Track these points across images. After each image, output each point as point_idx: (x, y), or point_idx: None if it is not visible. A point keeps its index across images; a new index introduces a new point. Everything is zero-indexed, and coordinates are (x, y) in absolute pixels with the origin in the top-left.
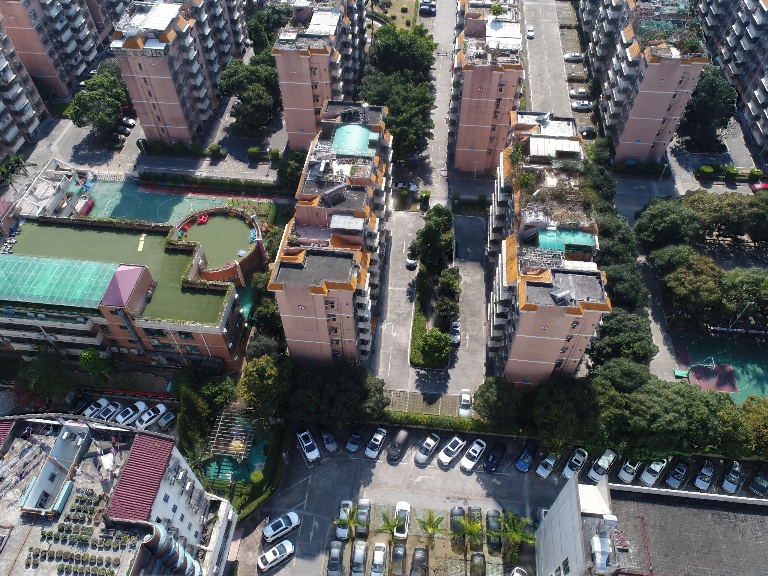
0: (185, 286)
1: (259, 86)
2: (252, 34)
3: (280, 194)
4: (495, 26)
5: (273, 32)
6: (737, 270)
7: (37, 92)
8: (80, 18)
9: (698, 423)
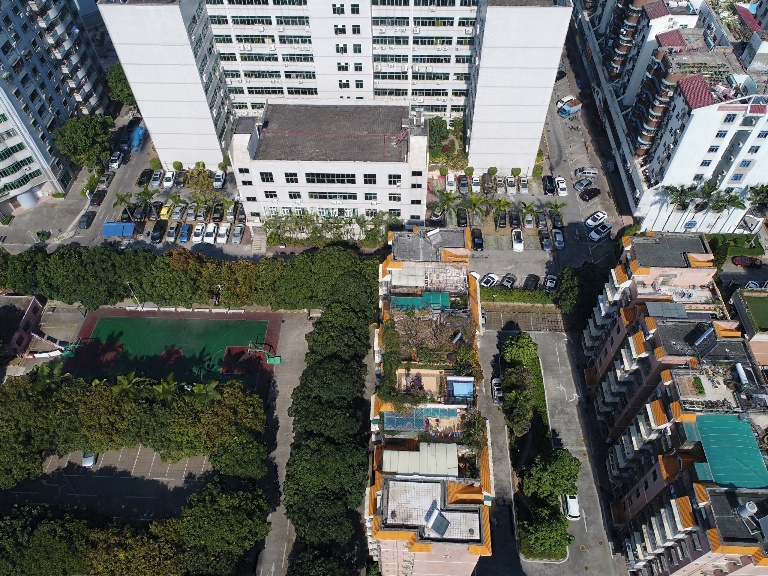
0: None
1: None
2: None
3: None
4: None
5: None
6: (166, 457)
7: None
8: None
9: (306, 254)
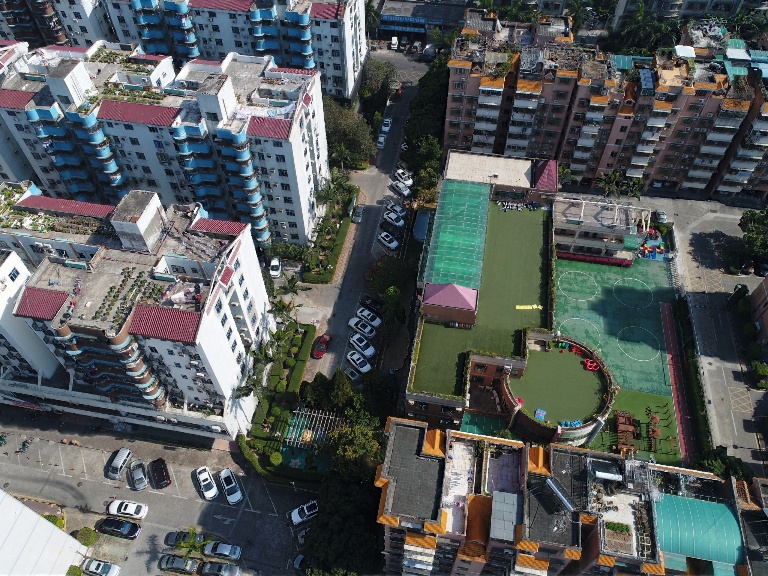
0: None
1: None
2: None
3: None
4: None
5: None
6: None
7: None
8: None
9: None
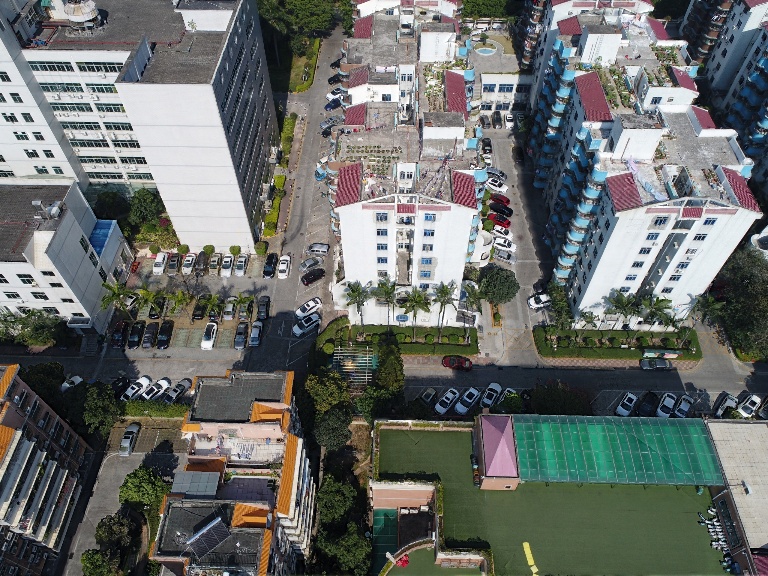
0: None
1: None
2: None
3: None
4: None
5: None
6: None
7: None
8: None
9: None
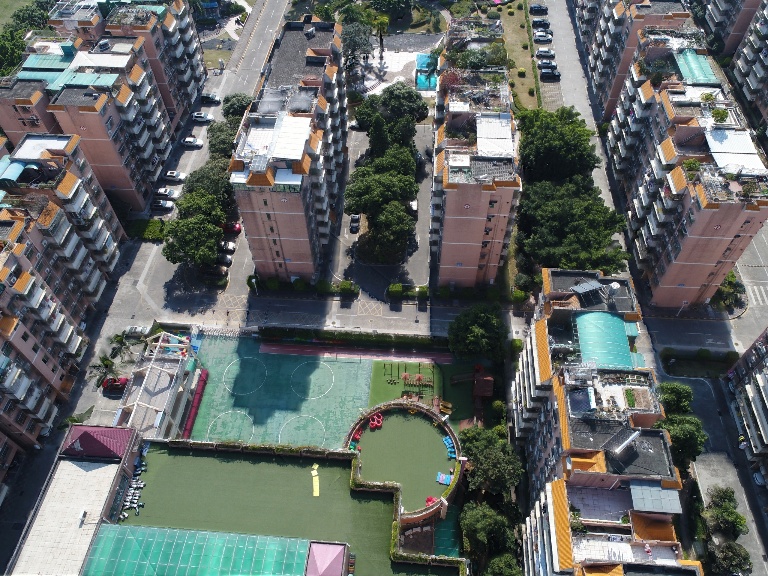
0: (396, 561)
1: (398, 206)
2: (363, 123)
3: (440, 350)
4: (717, 136)
5: (393, 122)
6: None
7: (115, 216)
8: (156, 112)
9: None
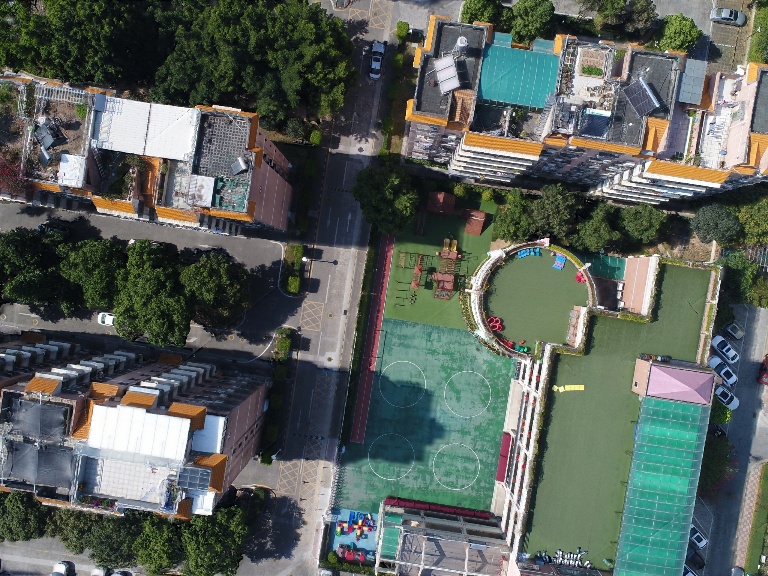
0: None
1: (191, 274)
2: None
3: (378, 241)
4: None
5: (4, 266)
6: None
7: None
8: None
9: None
